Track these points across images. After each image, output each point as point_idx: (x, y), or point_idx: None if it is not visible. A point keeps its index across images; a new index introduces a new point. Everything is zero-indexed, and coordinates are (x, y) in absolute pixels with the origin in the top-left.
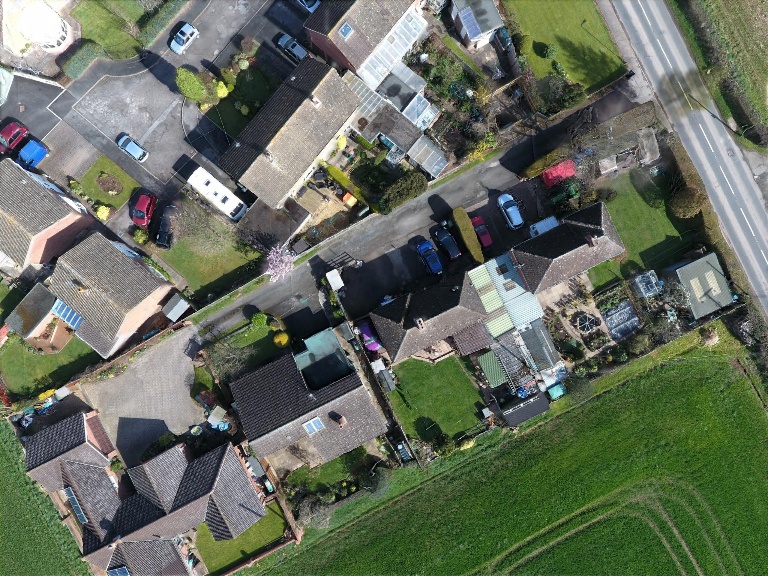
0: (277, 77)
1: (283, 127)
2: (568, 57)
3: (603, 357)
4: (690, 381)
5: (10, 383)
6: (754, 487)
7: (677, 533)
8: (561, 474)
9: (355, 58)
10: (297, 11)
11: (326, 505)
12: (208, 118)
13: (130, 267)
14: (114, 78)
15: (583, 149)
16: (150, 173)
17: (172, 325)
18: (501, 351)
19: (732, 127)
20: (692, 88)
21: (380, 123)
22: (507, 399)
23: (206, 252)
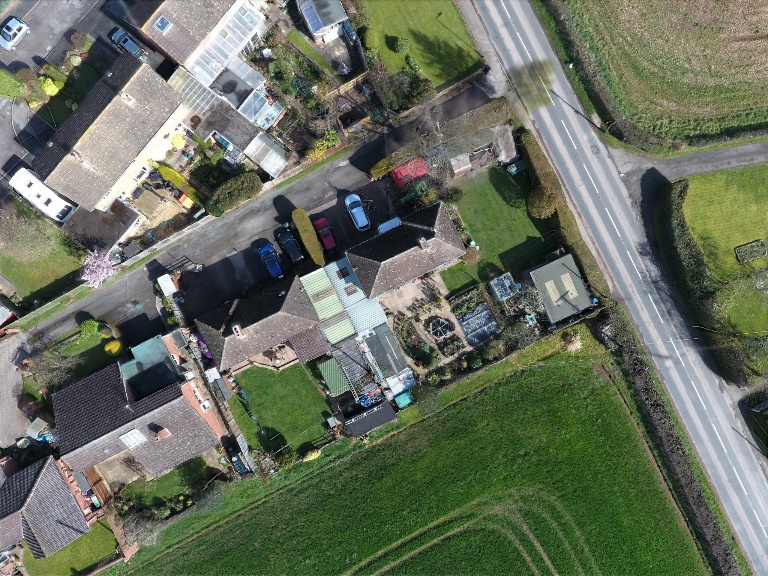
0: None
1: (91, 126)
2: (422, 51)
3: (458, 363)
4: (551, 388)
5: None
6: (620, 497)
7: (538, 546)
8: (414, 485)
9: (178, 53)
10: None
11: (160, 520)
12: (39, 117)
13: None
14: None
15: (432, 147)
16: None
17: None
18: (343, 358)
19: (596, 123)
20: (554, 83)
21: (214, 121)
22: (355, 408)
23: (36, 257)
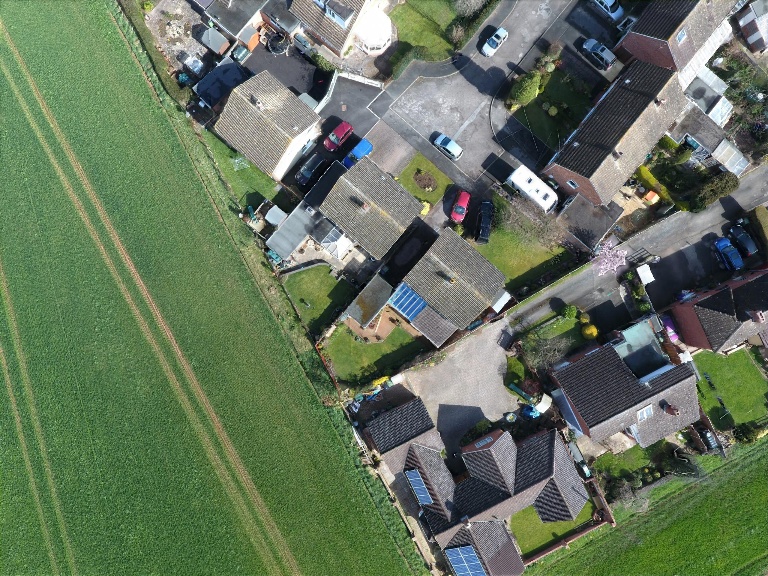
0: (579, 79)
1: (631, 128)
2: None
3: None
4: None
5: (338, 370)
6: None
7: None
8: None
9: (681, 62)
10: (596, 16)
11: (634, 490)
12: (515, 118)
13: (480, 260)
14: (428, 79)
15: None
16: (461, 171)
17: (496, 316)
18: None
19: None
20: None
21: (687, 124)
22: None
23: (515, 247)
